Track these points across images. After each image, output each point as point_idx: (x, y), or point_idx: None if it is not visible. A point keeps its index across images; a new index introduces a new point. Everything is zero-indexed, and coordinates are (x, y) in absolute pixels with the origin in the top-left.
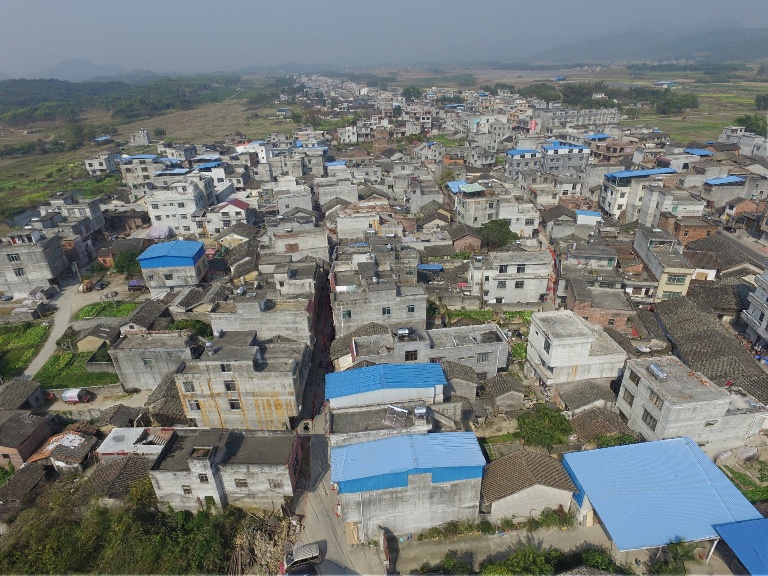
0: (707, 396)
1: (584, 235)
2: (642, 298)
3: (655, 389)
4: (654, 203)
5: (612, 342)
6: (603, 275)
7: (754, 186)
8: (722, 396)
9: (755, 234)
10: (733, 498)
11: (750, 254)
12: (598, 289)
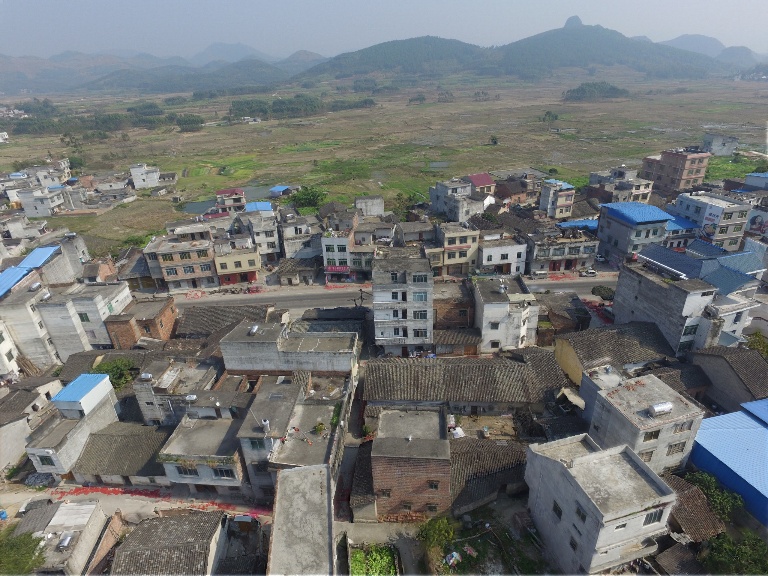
0: (665, 387)
1: (104, 420)
2: (351, 402)
3: (684, 420)
4: (76, 318)
5: (562, 442)
6: (326, 419)
7: (74, 249)
8: (656, 378)
9: (151, 290)
10: (737, 421)
11: (198, 306)
12: (378, 433)
